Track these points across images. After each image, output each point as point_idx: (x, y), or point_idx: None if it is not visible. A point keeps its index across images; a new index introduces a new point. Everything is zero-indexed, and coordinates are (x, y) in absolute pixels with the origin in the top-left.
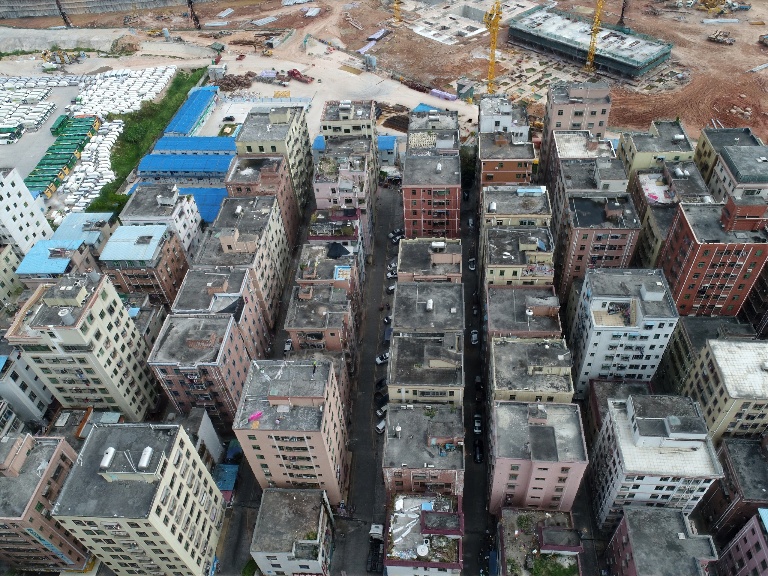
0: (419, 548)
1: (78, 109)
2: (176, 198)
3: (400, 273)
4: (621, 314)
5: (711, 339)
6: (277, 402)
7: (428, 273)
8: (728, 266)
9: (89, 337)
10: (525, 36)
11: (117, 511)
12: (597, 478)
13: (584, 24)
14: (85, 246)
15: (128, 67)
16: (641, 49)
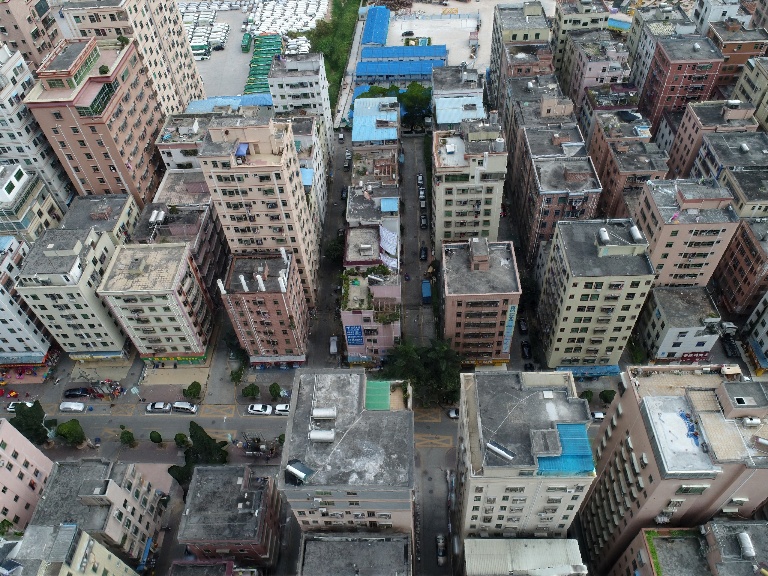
0: None
1: (255, 29)
2: None
3: (704, 127)
4: None
5: None
6: (689, 206)
7: None
8: None
9: None
10: None
11: (622, 273)
12: None
13: None
14: None
15: None
16: None
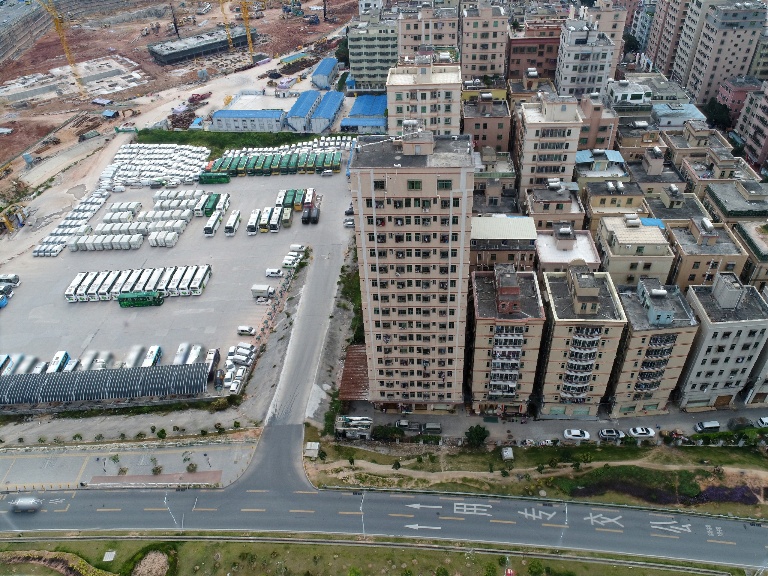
0: None
1: None
2: None
3: None
4: None
5: None
6: None
7: None
8: None
9: None
10: (179, 55)
11: None
12: None
13: (186, 39)
14: None
15: (88, 176)
16: (237, 30)
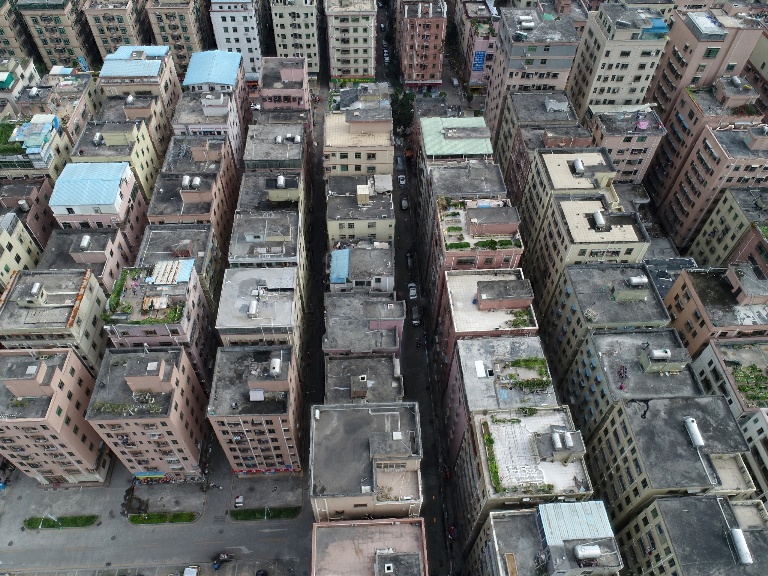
0: None
1: None
2: None
3: None
4: None
5: None
6: None
7: None
8: None
9: None
10: None
11: None
12: None
13: None
14: None
15: None
16: None
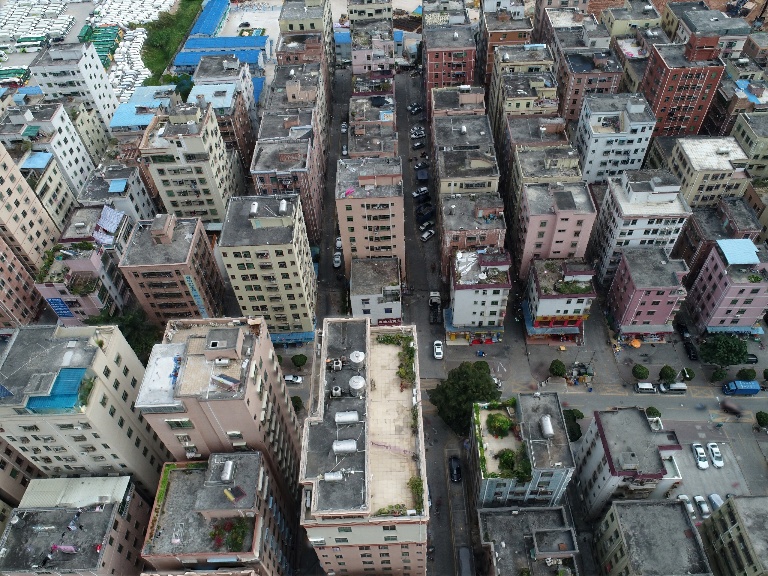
0: (480, 275)
1: (98, 21)
2: (238, 63)
3: (436, 110)
4: (612, 126)
5: (680, 138)
6: (365, 182)
7: (458, 110)
8: (691, 89)
9: (206, 148)
10: None
11: None
12: (599, 246)
13: None
14: (162, 107)
15: None
16: None
